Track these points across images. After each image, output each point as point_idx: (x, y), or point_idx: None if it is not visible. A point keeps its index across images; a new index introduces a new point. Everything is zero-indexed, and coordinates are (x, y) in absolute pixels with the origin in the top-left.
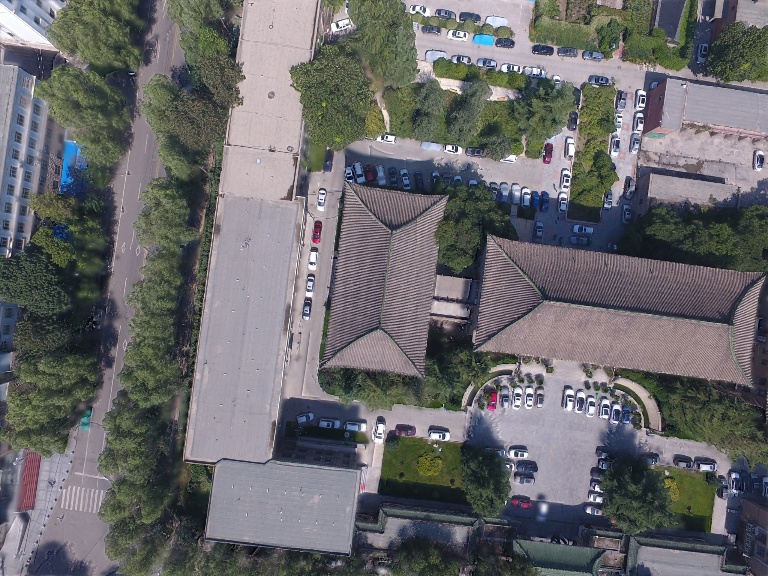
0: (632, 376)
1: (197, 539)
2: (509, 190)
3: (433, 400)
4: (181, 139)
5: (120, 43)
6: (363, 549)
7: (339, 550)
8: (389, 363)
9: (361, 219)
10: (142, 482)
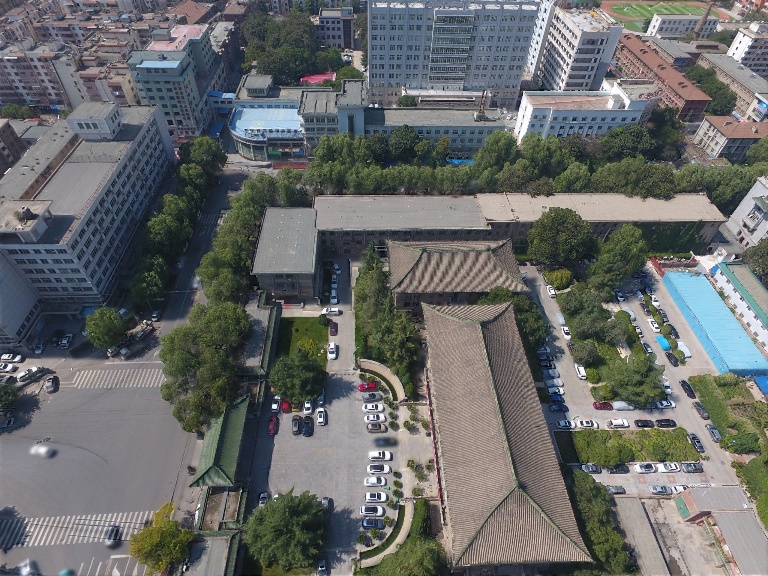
0: (420, 507)
1: (255, 223)
2: (555, 378)
3: (362, 340)
4: (499, 181)
5: (537, 161)
6: (246, 297)
7: (255, 268)
8: (397, 271)
9: (490, 246)
10: (297, 189)
